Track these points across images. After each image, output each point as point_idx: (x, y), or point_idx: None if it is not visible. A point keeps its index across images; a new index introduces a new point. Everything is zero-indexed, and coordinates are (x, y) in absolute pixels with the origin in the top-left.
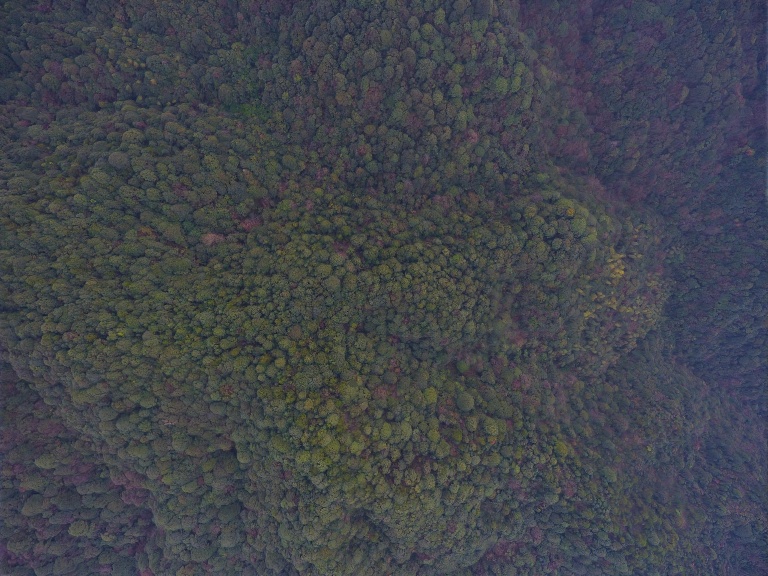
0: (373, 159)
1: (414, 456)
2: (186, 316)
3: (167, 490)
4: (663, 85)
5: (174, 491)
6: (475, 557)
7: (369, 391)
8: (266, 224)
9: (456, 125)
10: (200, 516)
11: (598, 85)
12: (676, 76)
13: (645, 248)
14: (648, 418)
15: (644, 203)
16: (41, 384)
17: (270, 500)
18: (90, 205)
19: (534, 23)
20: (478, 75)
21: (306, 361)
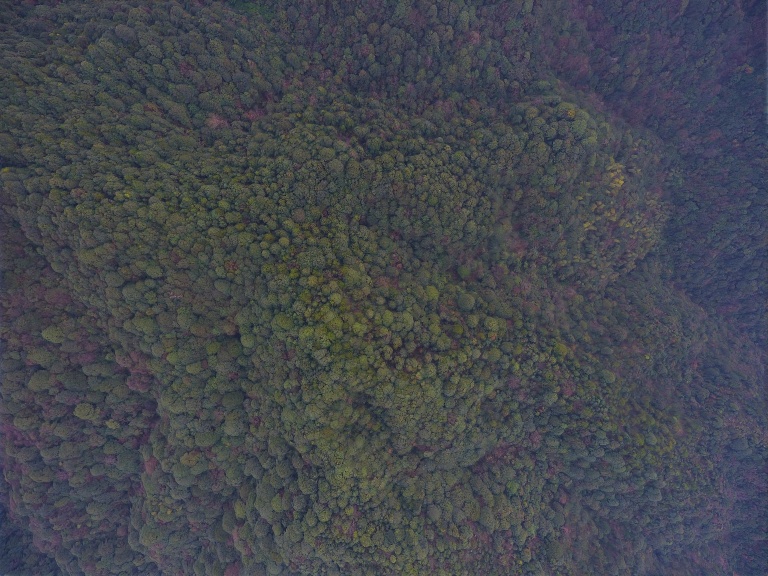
0: (376, 61)
1: (415, 346)
2: (192, 188)
3: (172, 370)
4: None
5: (179, 371)
6: (475, 455)
7: (371, 279)
8: (270, 115)
9: (458, 25)
10: (204, 400)
11: None
12: None
13: (644, 164)
14: (646, 330)
15: (644, 126)
16: (49, 243)
17: (273, 383)
18: (97, 73)
19: None
20: None
21: (309, 241)
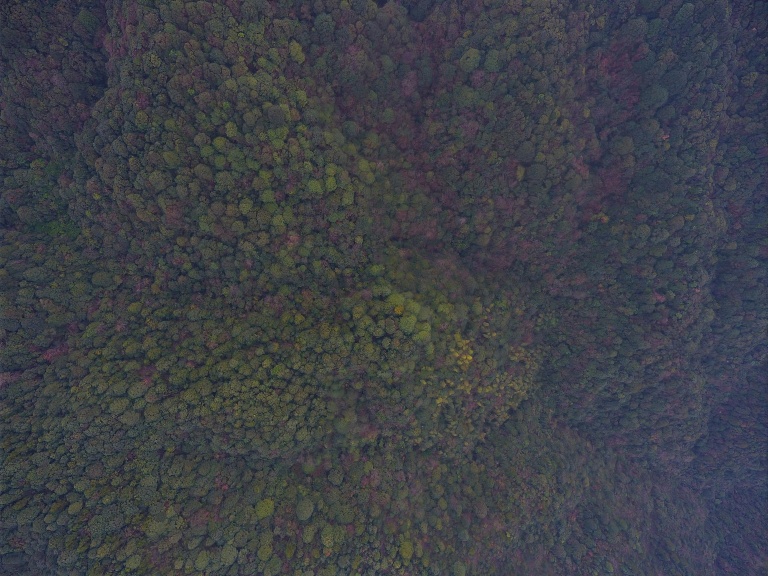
0: (194, 267)
1: None
2: None
3: None
4: (496, 166)
5: None
6: None
7: (184, 519)
8: (69, 353)
9: (272, 230)
10: None
11: (438, 164)
12: (507, 157)
13: (502, 324)
14: (510, 500)
15: (510, 270)
16: None
17: None
18: None
19: (355, 113)
20: (288, 179)
21: (103, 503)
